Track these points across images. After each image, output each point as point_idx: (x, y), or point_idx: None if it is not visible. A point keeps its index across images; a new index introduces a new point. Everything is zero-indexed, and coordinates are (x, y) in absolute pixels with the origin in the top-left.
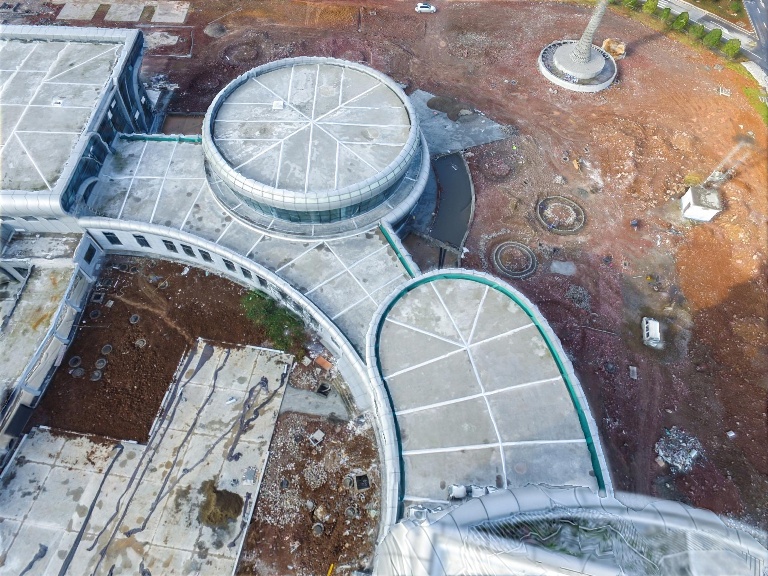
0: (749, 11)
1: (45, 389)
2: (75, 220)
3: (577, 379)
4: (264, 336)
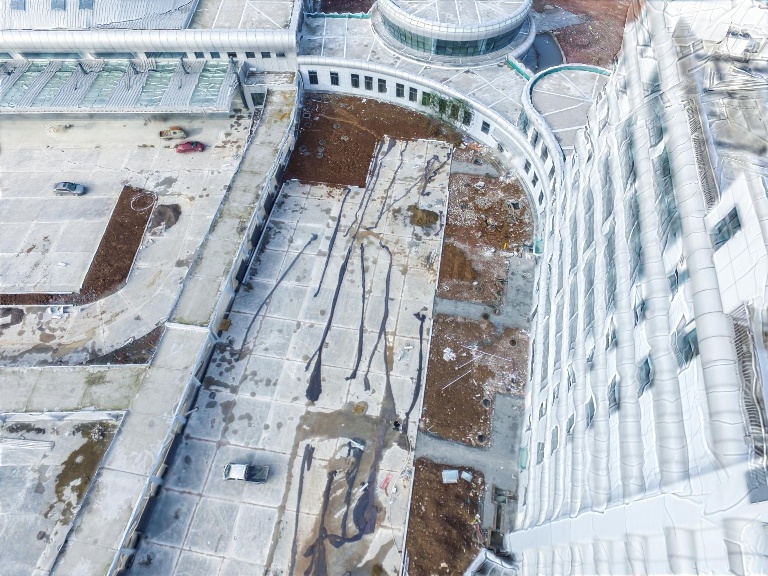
0: None
1: (288, 162)
2: (295, 57)
3: None
4: (429, 134)
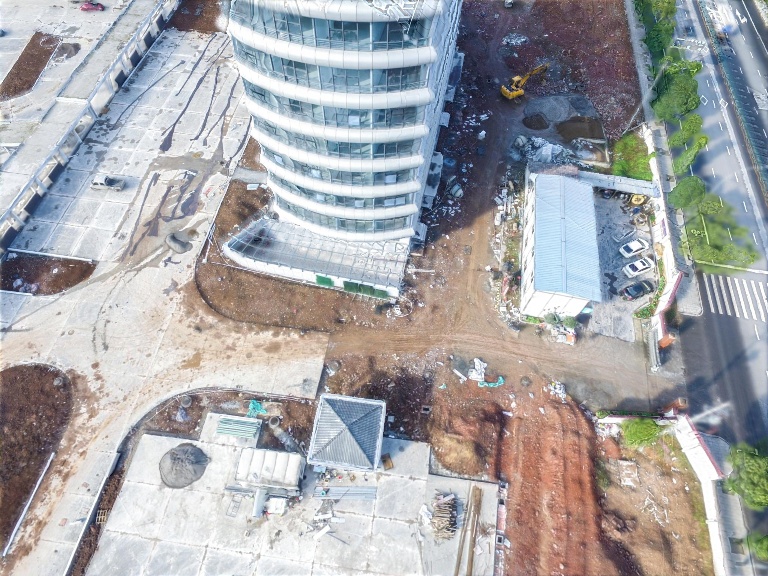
0: None
1: (171, 17)
2: None
3: None
4: None
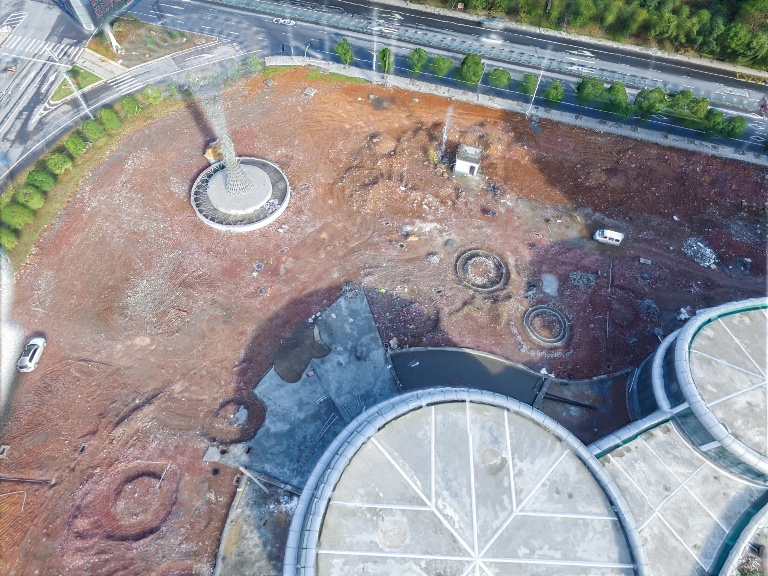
0: (178, 28)
1: None
2: None
3: (763, 298)
4: None
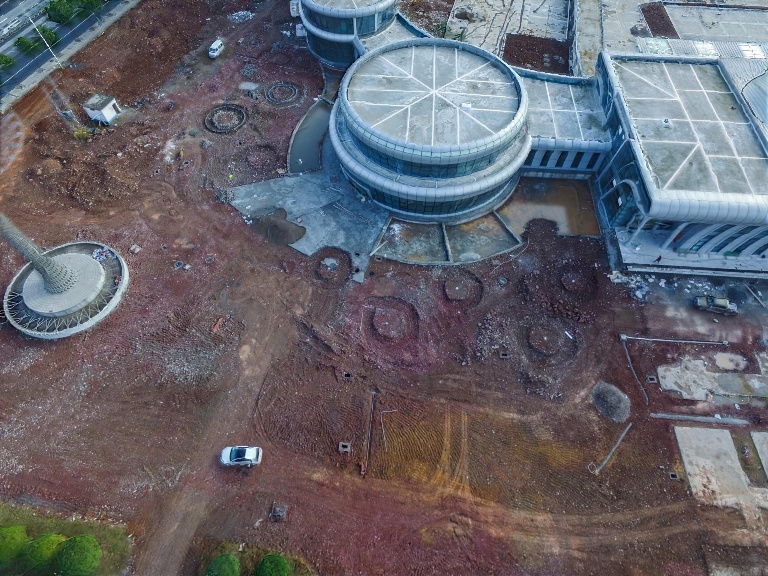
0: None
1: None
2: None
3: None
4: None
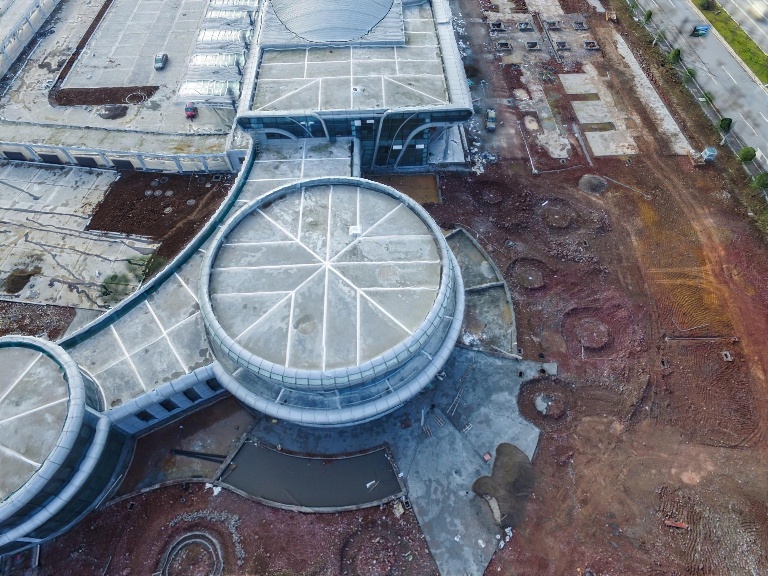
0: None
1: (147, 171)
2: (250, 137)
3: None
4: None
